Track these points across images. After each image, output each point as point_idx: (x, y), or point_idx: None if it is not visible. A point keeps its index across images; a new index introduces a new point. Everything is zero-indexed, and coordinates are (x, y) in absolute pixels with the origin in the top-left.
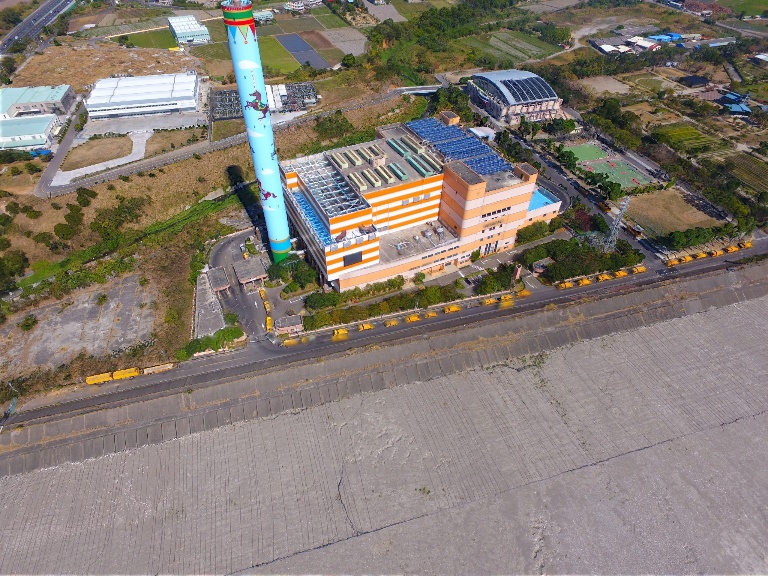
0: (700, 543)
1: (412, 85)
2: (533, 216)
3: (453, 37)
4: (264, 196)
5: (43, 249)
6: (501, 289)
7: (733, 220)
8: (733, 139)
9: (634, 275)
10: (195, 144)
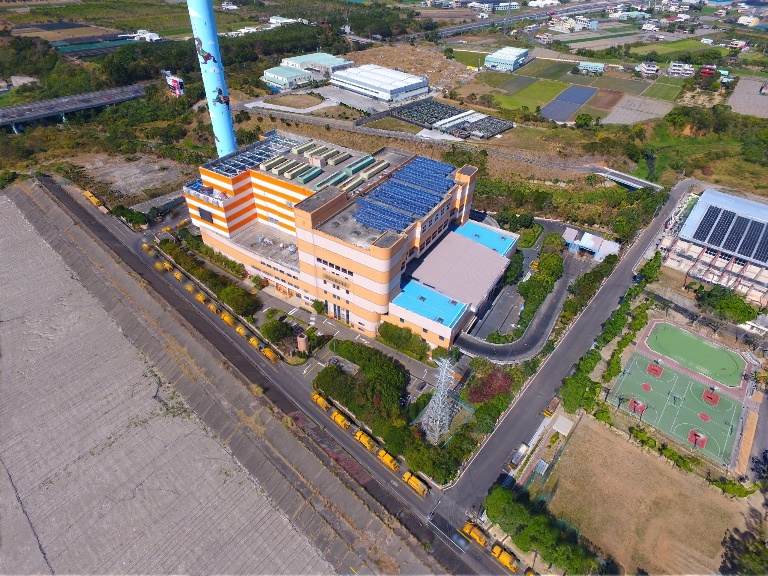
0: None
1: (639, 175)
2: (406, 318)
3: None
4: None
5: None
6: (282, 346)
7: None
8: None
9: (402, 481)
10: (341, 120)
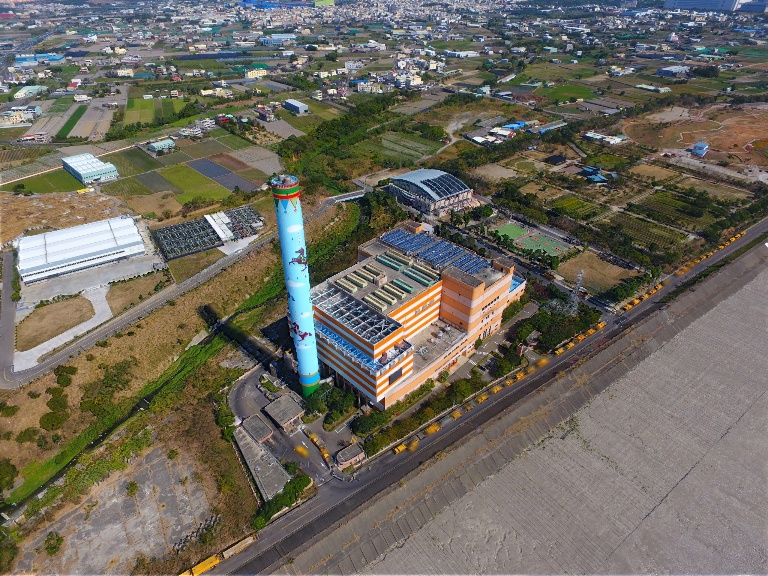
0: (762, 542)
1: (337, 193)
2: (509, 298)
3: (350, 144)
4: (301, 337)
5: (30, 449)
6: None
7: (640, 268)
8: (607, 203)
9: (600, 330)
10: (163, 290)
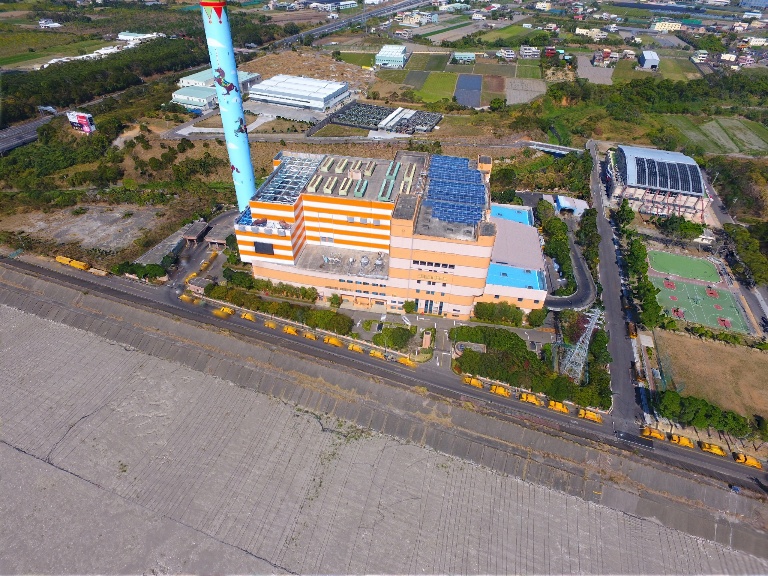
0: None
1: (554, 143)
2: (501, 294)
3: (657, 111)
4: None
5: None
6: (401, 350)
7: None
8: None
9: (578, 418)
10: (292, 134)
